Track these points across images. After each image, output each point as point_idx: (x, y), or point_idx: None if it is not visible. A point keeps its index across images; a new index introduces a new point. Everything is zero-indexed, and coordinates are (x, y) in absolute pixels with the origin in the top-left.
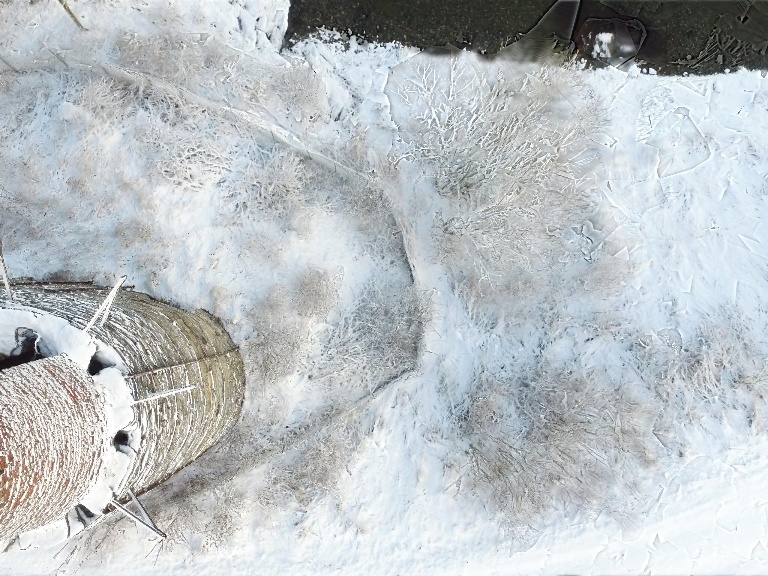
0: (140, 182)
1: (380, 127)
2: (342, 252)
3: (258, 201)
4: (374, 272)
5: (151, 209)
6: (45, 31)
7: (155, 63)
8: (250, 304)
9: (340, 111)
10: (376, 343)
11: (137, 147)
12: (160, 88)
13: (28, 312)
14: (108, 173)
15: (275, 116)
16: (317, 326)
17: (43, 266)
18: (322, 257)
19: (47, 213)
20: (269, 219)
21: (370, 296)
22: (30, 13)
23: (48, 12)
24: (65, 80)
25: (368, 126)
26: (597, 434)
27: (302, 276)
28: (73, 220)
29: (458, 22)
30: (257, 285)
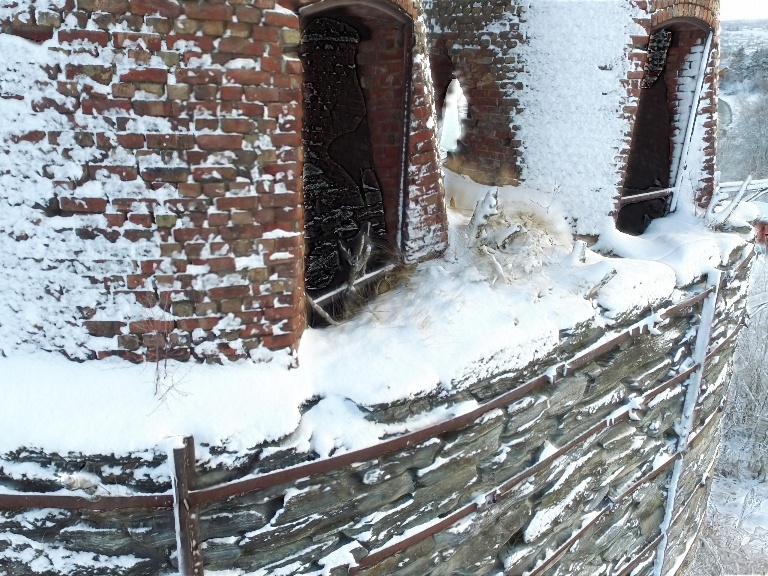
0: None
1: None
2: None
3: None
4: None
5: None
6: None
7: None
8: None
9: None
10: None
11: None
12: None
13: None
14: None
15: None
16: None
17: None
18: None
19: None
20: None
21: None
22: None
23: None
24: None
25: None
26: (766, 341)
27: None
28: None
29: None
30: None
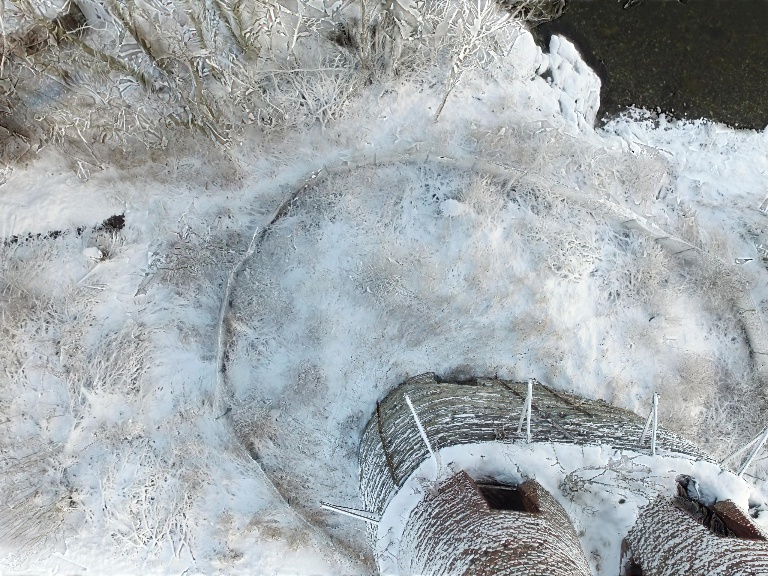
0: (529, 276)
1: (701, 204)
2: (695, 332)
3: (630, 289)
4: (721, 350)
5: (544, 303)
6: (395, 123)
7: (516, 155)
8: (644, 393)
9: (660, 189)
10: (740, 422)
11: (520, 241)
12: (532, 182)
13: (687, 460)
14: (499, 268)
15: (618, 200)
16: (695, 409)
17: (443, 361)
18: (683, 339)
19: (445, 309)
20: (637, 305)
21: (722, 374)
22: (380, 106)
23: (397, 105)
24: (424, 172)
25: (690, 204)
26: None
27: (690, 364)
28: (468, 315)
29: (761, 97)
30: (644, 373)
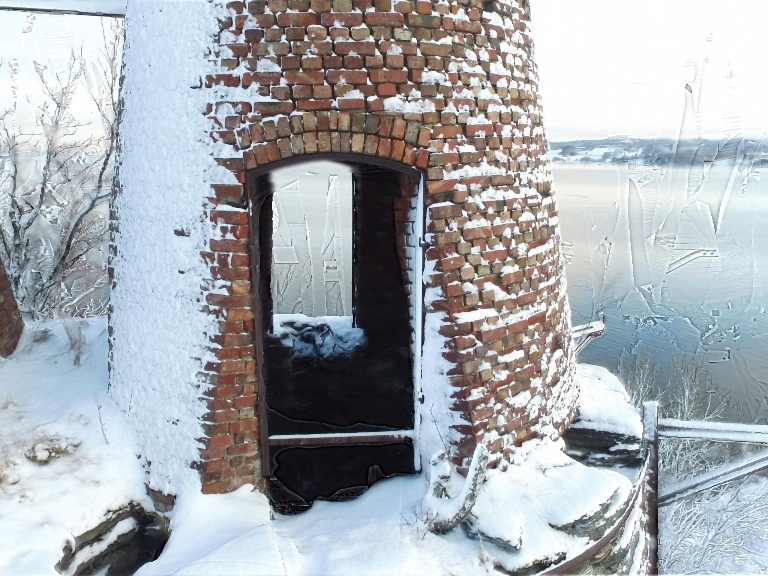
0: None
1: None
2: None
3: None
4: None
5: None
6: None
7: None
8: None
9: None
10: None
11: None
12: None
13: None
14: None
15: None
16: None
17: None
18: None
19: None
20: None
21: None
22: None
23: None
24: None
25: None
26: None
27: None
28: None
29: None
30: None
